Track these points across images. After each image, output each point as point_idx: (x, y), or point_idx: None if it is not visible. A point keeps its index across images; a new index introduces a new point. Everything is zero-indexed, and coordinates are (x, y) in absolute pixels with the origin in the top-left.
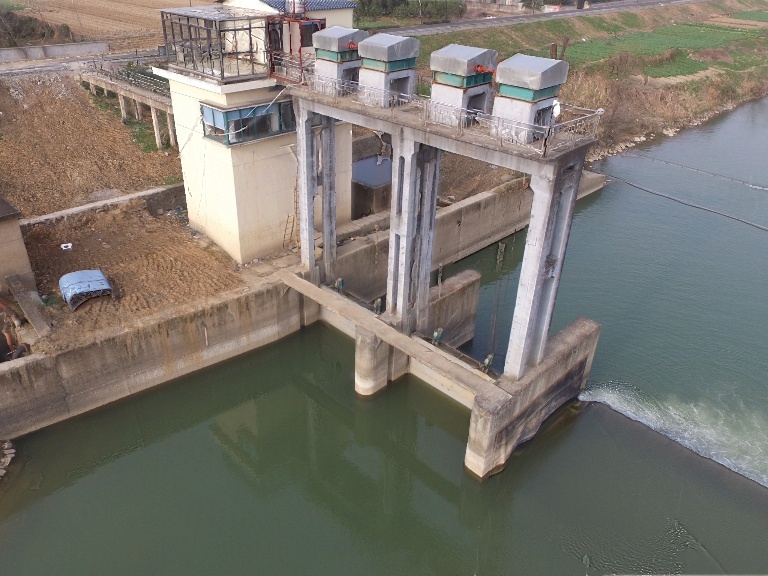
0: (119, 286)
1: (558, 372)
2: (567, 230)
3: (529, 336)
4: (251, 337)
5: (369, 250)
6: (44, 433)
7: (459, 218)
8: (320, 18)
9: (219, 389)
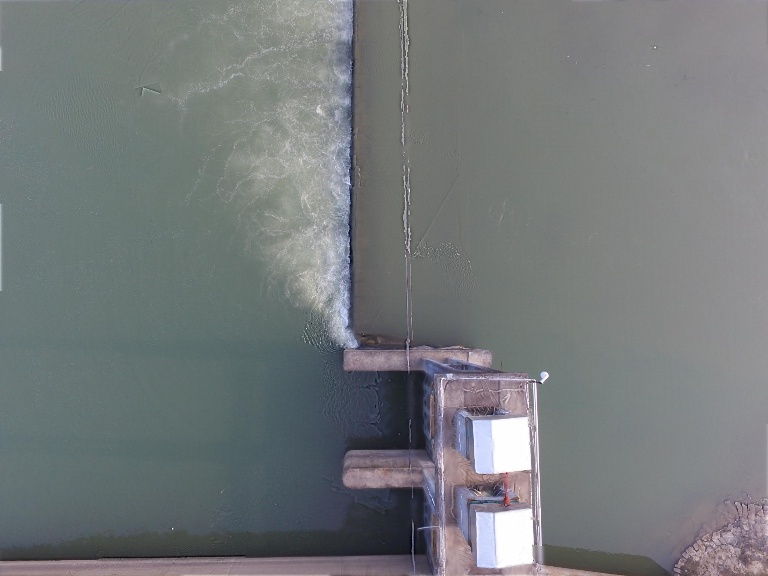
0: None
1: None
2: None
3: None
4: None
5: None
6: None
7: None
8: None
9: None
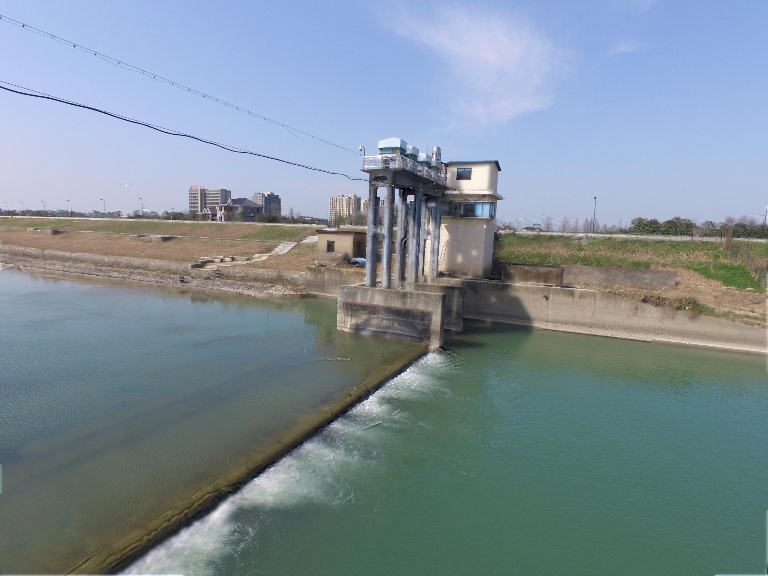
0: None
1: (396, 301)
2: (388, 210)
3: (370, 262)
4: None
5: (459, 283)
6: (316, 297)
7: (547, 294)
8: (469, 168)
9: None
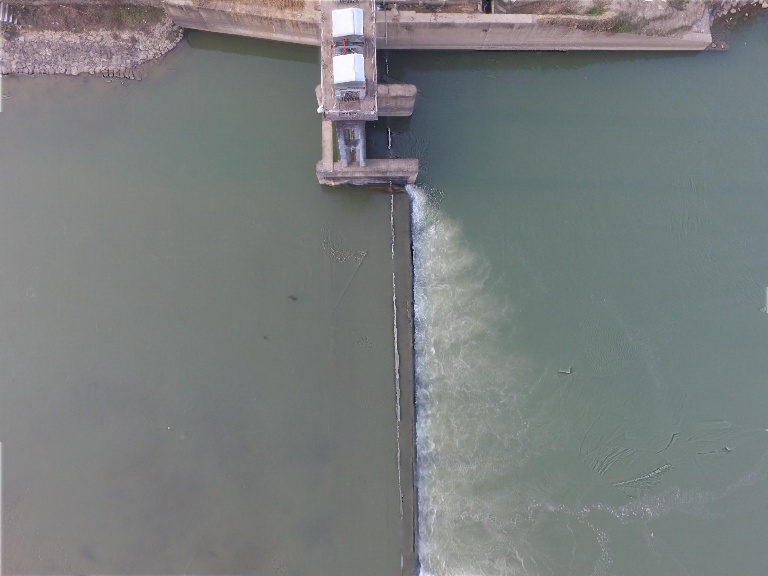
0: None
1: (376, 174)
2: (362, 139)
3: (345, 158)
4: (301, 38)
5: (392, 24)
6: (198, 31)
7: (487, 28)
8: None
9: (284, 51)
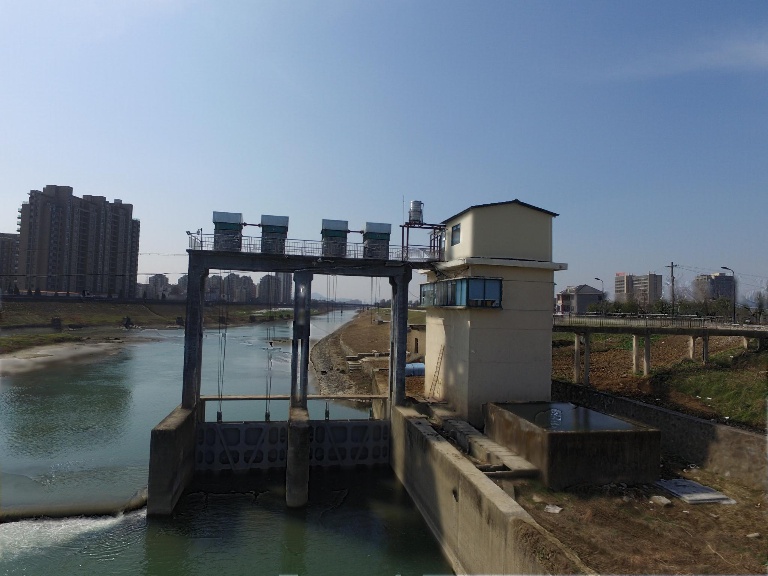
0: (417, 376)
1: None
2: None
3: None
4: None
5: None
6: None
7: None
8: None
9: None
